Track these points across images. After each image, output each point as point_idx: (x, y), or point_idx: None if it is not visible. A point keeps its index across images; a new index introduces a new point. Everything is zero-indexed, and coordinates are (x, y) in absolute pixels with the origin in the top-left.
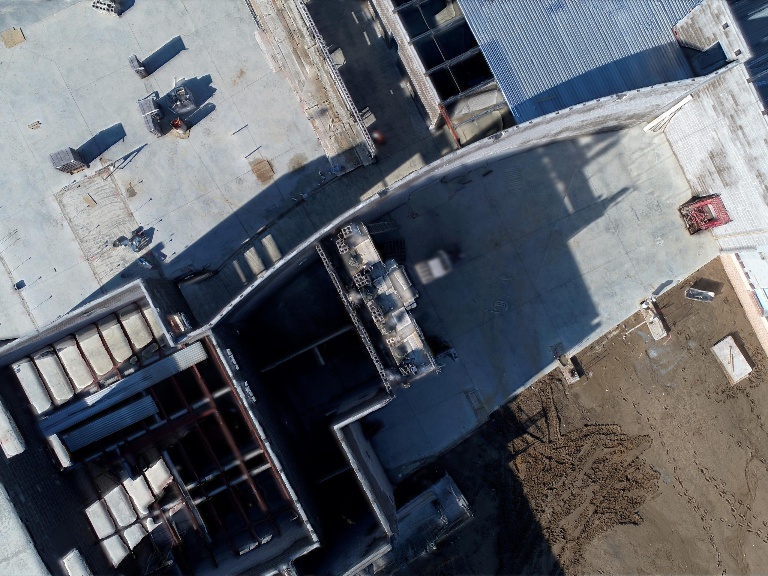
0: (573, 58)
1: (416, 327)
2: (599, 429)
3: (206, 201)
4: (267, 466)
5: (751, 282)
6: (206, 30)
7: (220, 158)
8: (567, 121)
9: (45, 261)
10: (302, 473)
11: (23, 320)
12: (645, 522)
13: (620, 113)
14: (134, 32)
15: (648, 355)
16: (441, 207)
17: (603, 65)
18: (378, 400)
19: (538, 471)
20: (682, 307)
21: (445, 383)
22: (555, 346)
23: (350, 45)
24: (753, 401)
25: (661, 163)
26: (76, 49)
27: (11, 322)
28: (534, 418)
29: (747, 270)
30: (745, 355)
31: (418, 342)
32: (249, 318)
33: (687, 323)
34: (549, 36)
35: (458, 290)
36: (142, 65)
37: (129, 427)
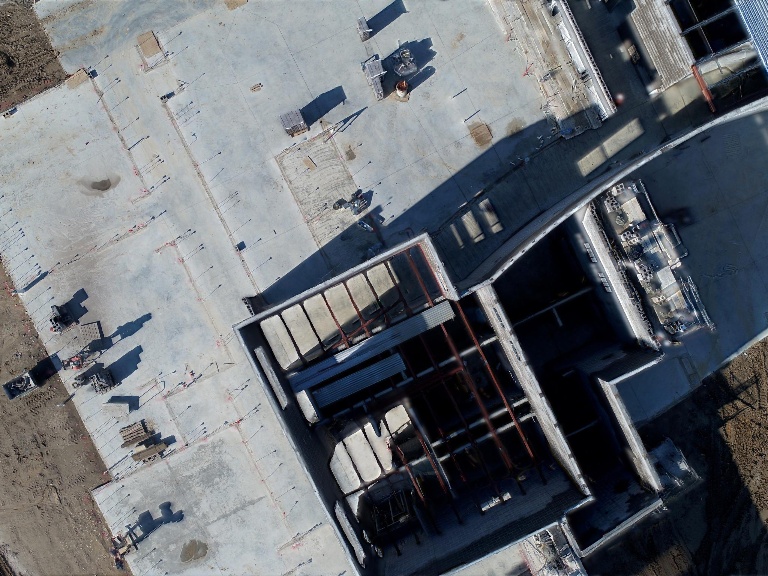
0: None
1: (692, 284)
2: None
3: (425, 165)
4: (510, 424)
5: None
6: None
7: (439, 122)
8: None
9: (265, 223)
10: None
11: (243, 281)
12: None
13: None
14: None
15: None
16: (658, 172)
17: None
18: (647, 357)
19: (747, 437)
20: None
21: None
22: None
23: (571, 9)
24: None
25: None
26: (298, 11)
27: (231, 283)
28: (745, 384)
29: None
30: None
31: (682, 301)
32: None
33: None
34: None
35: None
36: None
37: (376, 384)
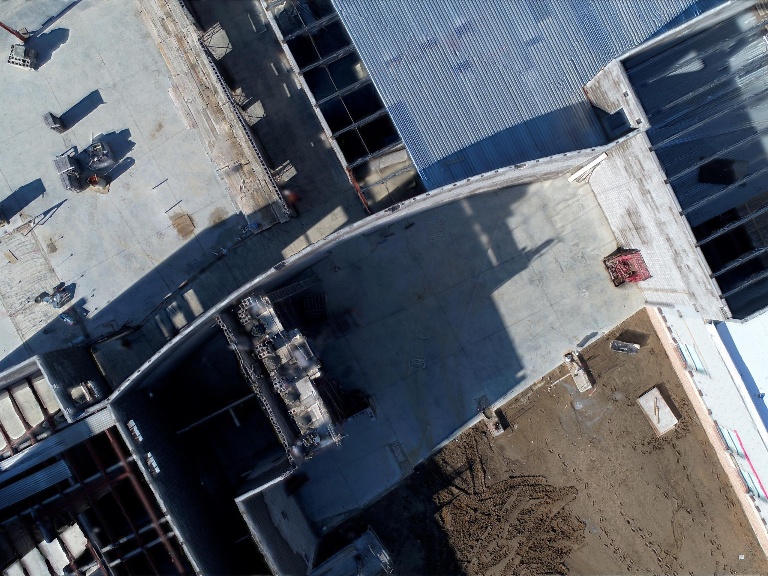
0: (482, 119)
1: None
2: (524, 480)
3: (127, 256)
4: None
5: (674, 336)
6: (124, 84)
7: (140, 213)
8: (474, 186)
9: None
10: (213, 537)
11: None
12: (571, 572)
13: (532, 173)
14: (52, 86)
15: (573, 407)
16: (363, 260)
17: (513, 126)
18: (280, 471)
19: (463, 522)
20: (608, 359)
21: (369, 436)
22: (479, 399)
23: (270, 97)
24: (679, 452)
25: (586, 214)
26: None
27: None
28: (459, 470)
29: (669, 324)
30: (671, 406)
31: None
32: (169, 375)
33: (613, 375)
34: (458, 97)
35: (381, 343)
36: (59, 120)
37: (42, 491)
